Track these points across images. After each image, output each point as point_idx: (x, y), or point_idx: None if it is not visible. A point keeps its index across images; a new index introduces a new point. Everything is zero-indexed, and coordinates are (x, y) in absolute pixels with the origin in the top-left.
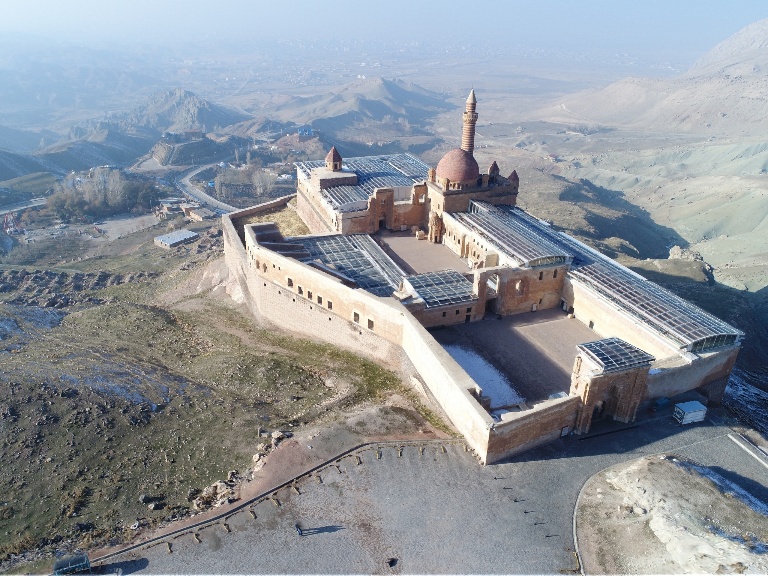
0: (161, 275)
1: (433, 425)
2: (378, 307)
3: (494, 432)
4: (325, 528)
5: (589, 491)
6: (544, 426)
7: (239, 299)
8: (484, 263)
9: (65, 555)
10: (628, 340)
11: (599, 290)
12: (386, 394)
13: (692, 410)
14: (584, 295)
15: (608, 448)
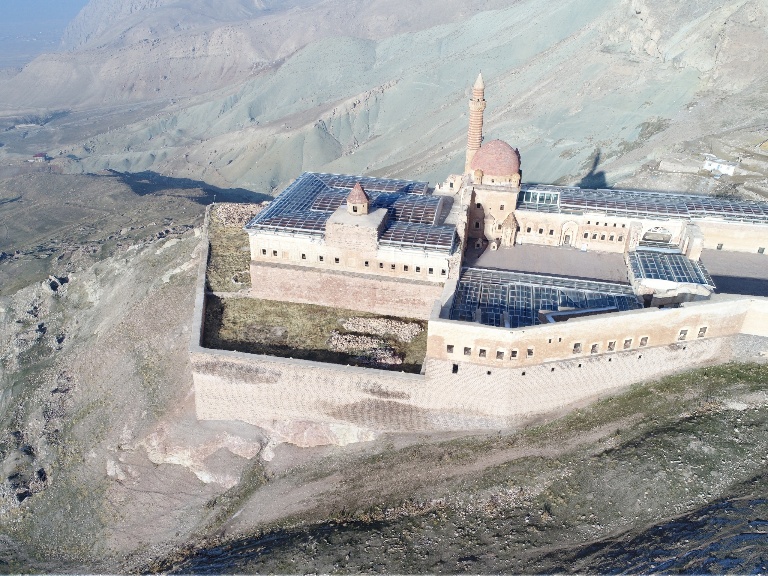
0: None
1: None
2: (719, 309)
3: None
4: None
5: None
6: None
7: (364, 436)
8: None
9: None
10: None
11: None
12: None
13: None
14: (710, 226)
15: None
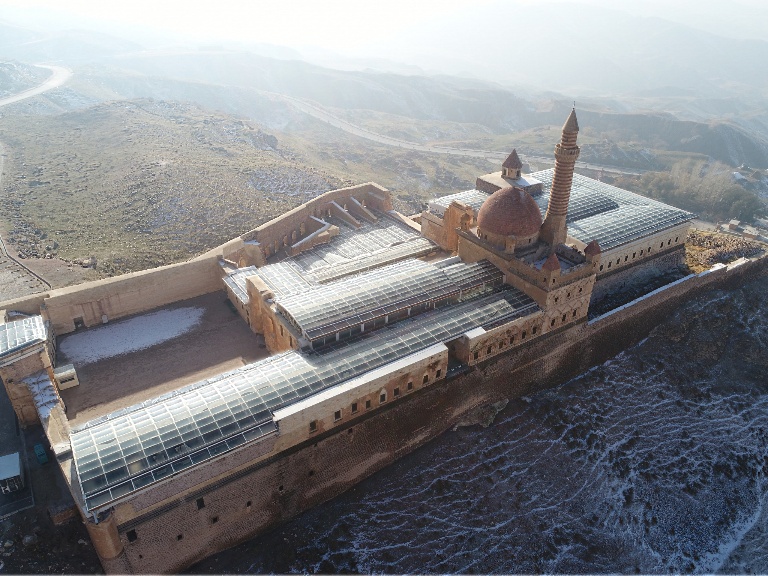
0: None
1: None
2: None
3: None
4: None
5: None
6: None
7: None
8: None
9: None
10: None
11: None
12: None
13: None
14: None
15: None
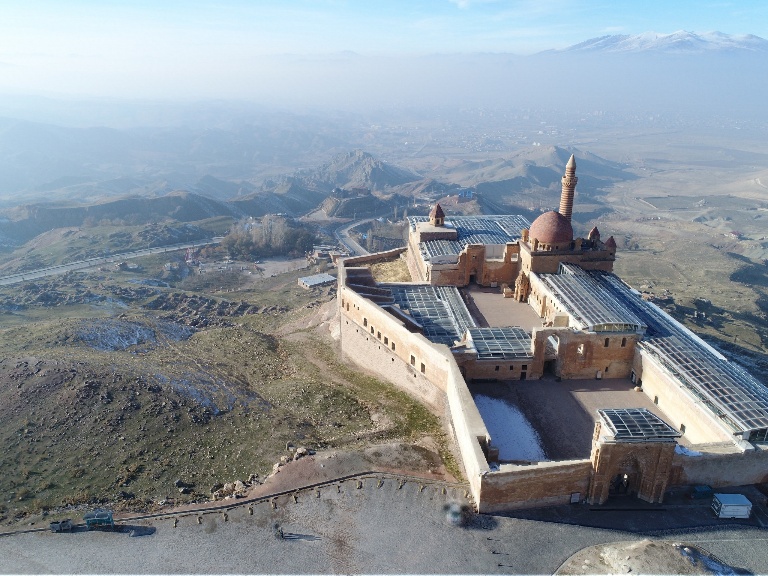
0: (290, 310)
1: (446, 468)
2: (429, 352)
3: (487, 480)
4: (305, 536)
5: (576, 560)
6: (548, 486)
7: (336, 336)
8: (553, 324)
9: (102, 512)
10: (687, 420)
11: (665, 364)
12: (421, 435)
13: (732, 503)
14: (651, 368)
15: (619, 524)
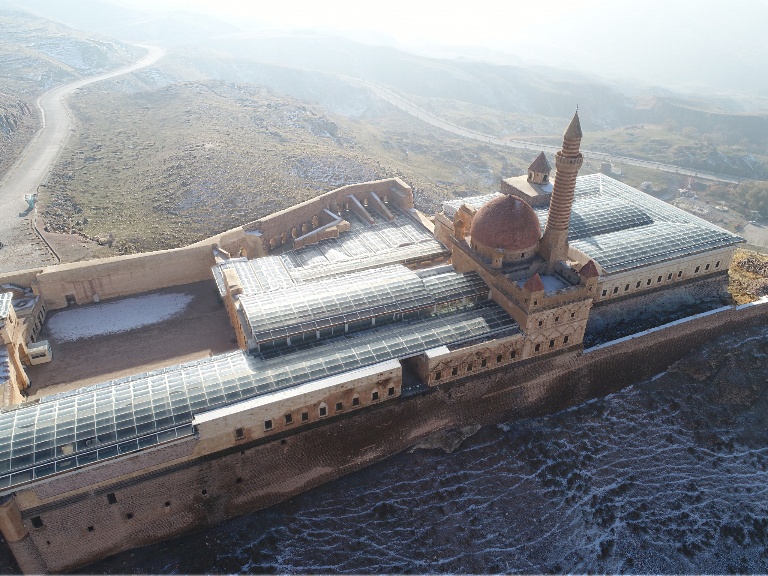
0: None
1: None
2: None
3: None
4: None
5: None
6: None
7: None
8: None
9: None
10: None
11: None
12: None
13: None
14: None
15: None
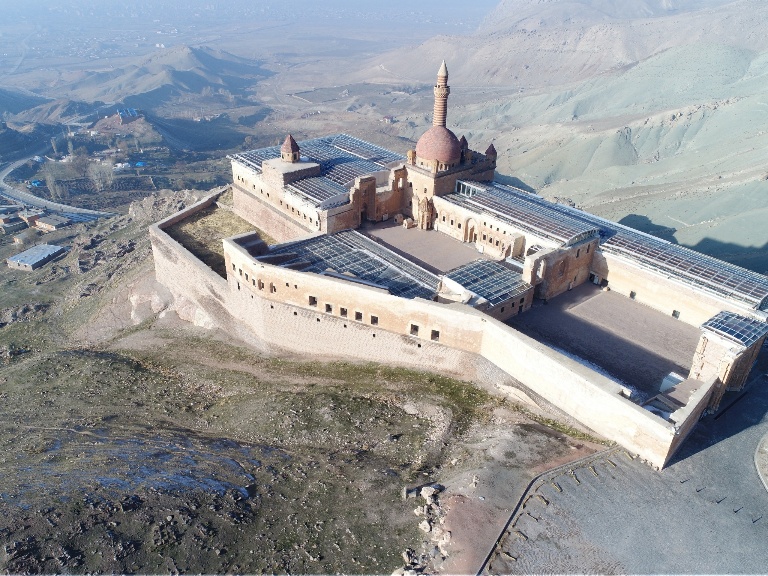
0: (51, 306)
1: (573, 437)
2: (447, 315)
3: None
4: None
5: (767, 472)
6: (695, 415)
7: (207, 324)
8: (512, 247)
9: None
10: (683, 306)
11: (641, 260)
12: (485, 410)
13: None
14: (622, 267)
15: (744, 421)
